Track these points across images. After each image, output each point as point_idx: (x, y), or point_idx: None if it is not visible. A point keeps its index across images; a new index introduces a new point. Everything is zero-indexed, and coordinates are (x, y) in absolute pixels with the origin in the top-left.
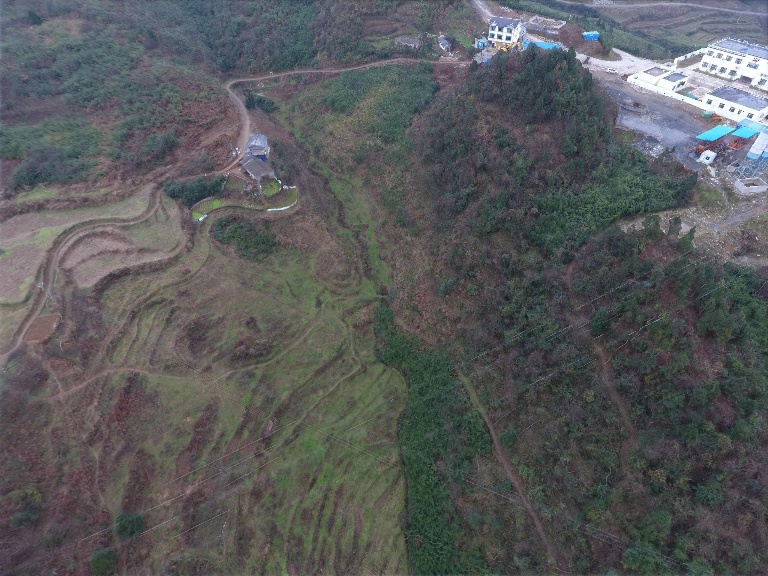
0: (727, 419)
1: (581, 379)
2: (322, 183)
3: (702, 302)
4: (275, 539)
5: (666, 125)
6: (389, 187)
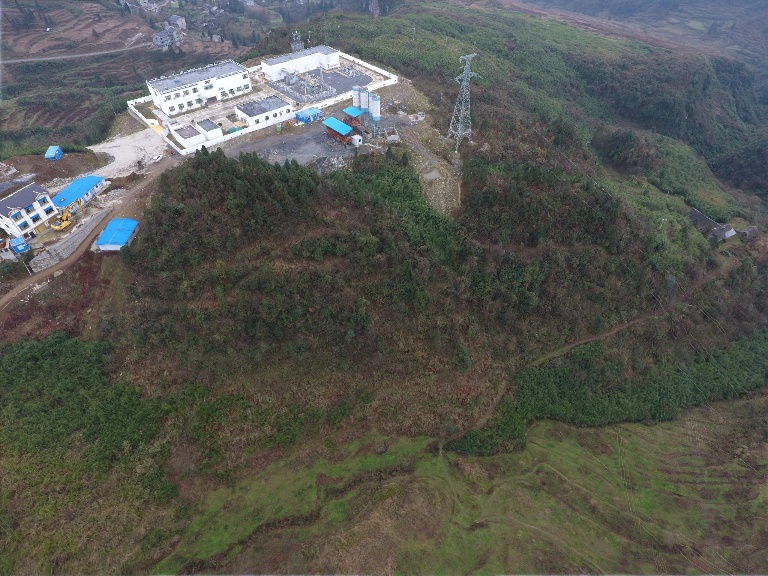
0: (606, 194)
1: (565, 263)
2: (200, 575)
3: (538, 176)
4: (744, 515)
5: (292, 150)
6: (268, 431)
